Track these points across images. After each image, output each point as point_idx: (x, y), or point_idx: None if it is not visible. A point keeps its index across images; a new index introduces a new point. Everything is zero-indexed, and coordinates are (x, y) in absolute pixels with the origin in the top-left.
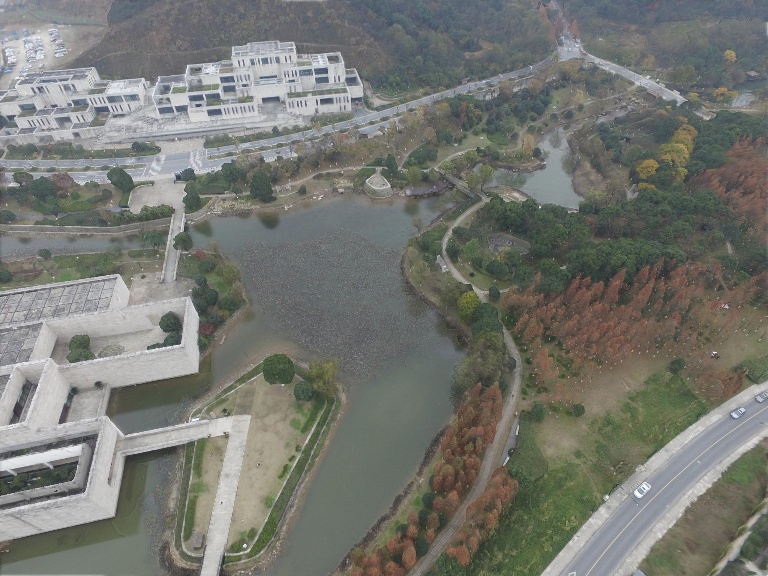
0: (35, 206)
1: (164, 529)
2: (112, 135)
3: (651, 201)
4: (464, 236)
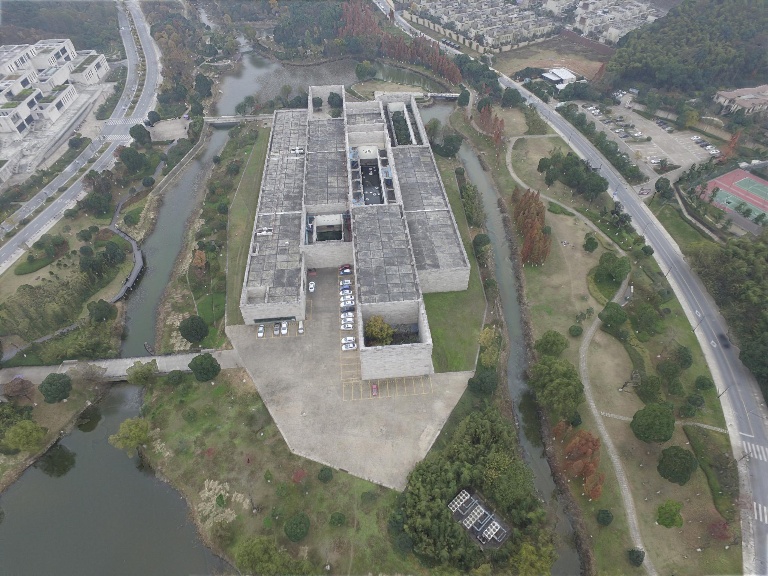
0: (138, 177)
1: (418, 107)
2: (30, 159)
3: (298, 7)
4: (294, 42)
